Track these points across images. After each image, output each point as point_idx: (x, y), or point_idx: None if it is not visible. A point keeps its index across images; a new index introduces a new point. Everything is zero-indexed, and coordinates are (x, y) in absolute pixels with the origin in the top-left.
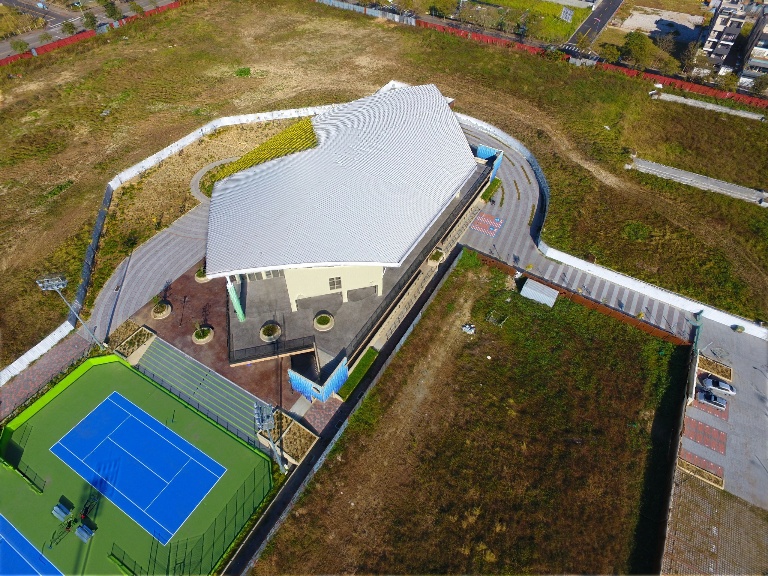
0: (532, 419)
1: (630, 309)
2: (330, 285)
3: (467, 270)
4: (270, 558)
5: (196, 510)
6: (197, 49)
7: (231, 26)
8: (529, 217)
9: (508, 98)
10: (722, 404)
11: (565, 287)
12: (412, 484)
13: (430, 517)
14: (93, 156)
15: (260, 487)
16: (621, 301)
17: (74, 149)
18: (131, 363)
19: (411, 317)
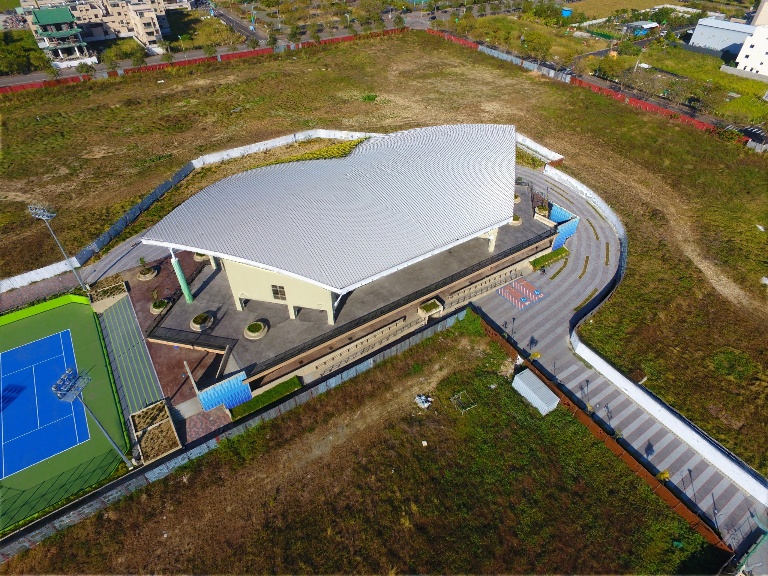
0: (425, 543)
1: (661, 462)
2: (274, 293)
3: (462, 335)
4: (49, 547)
5: (38, 464)
6: (344, 74)
7: (386, 60)
8: (581, 301)
9: (637, 169)
10: None
11: (578, 398)
12: (237, 547)
13: None
14: (202, 140)
15: (101, 471)
16: (653, 446)
17: (193, 132)
18: (96, 310)
19: None
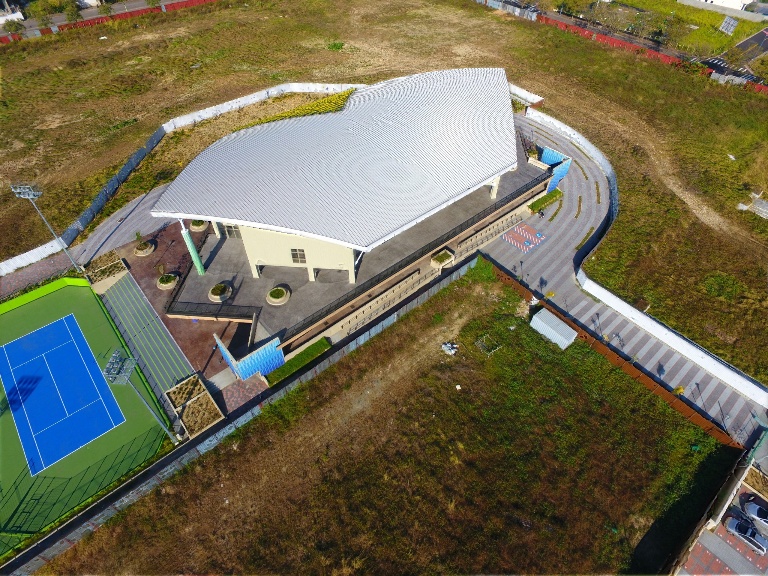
0: (477, 476)
1: (672, 379)
2: (293, 257)
3: (475, 282)
4: (113, 528)
5: (77, 451)
6: (304, 21)
7: (345, 4)
8: (580, 240)
9: (613, 107)
10: (761, 545)
11: (592, 330)
12: (300, 503)
13: (302, 549)
14: (166, 101)
15: (146, 449)
16: (663, 366)
17: (154, 93)
18: (97, 291)
19: (386, 317)
